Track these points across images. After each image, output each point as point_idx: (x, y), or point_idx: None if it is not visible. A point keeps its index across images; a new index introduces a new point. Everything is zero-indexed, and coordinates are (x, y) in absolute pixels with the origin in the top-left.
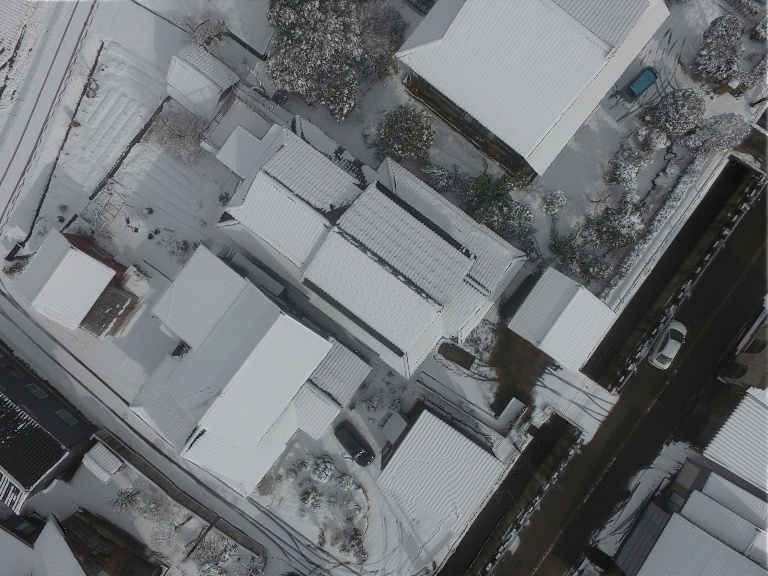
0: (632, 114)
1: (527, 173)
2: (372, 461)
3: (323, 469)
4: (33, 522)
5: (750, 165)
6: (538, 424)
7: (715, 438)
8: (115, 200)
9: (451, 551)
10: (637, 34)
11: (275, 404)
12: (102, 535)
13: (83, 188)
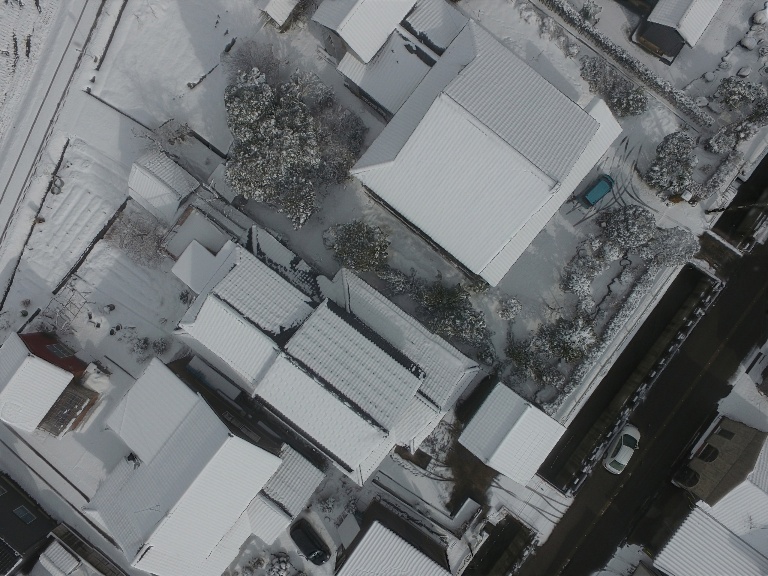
0: (589, 219)
1: None
2: (328, 560)
3: (277, 570)
4: None
5: (705, 272)
6: (494, 522)
7: (665, 549)
8: (78, 295)
9: None
10: (589, 151)
11: (224, 519)
12: None
13: (47, 283)
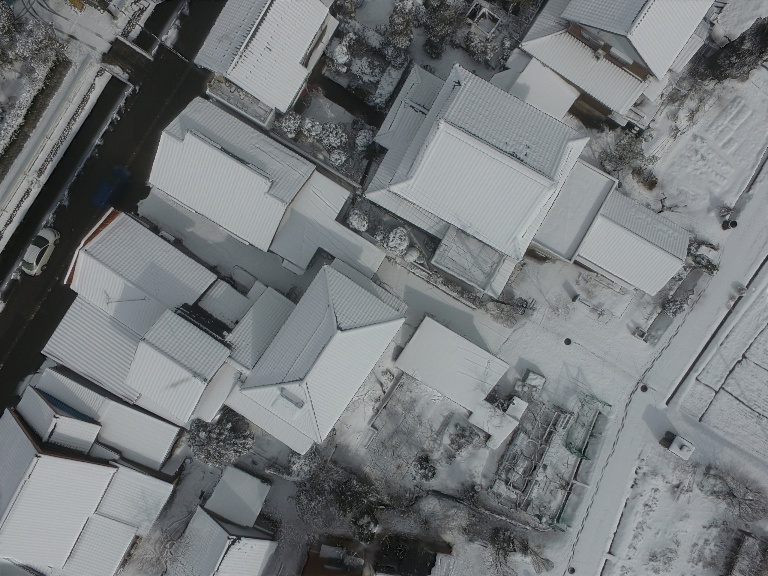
0: None
1: None
2: None
3: None
4: None
5: (116, 76)
6: None
7: (52, 335)
8: None
9: None
10: None
11: None
12: None
13: None
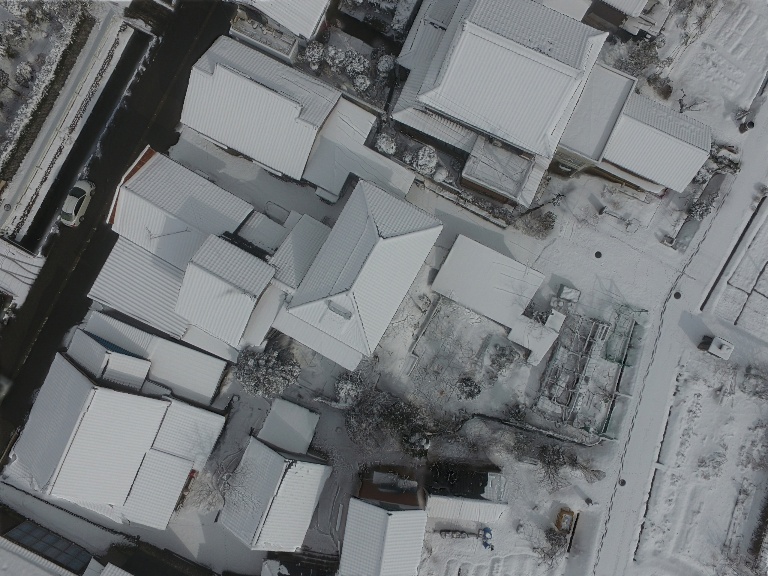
0: None
1: None
2: None
3: None
4: None
5: (139, 29)
6: None
7: (96, 279)
8: None
9: None
10: None
11: None
12: None
13: None
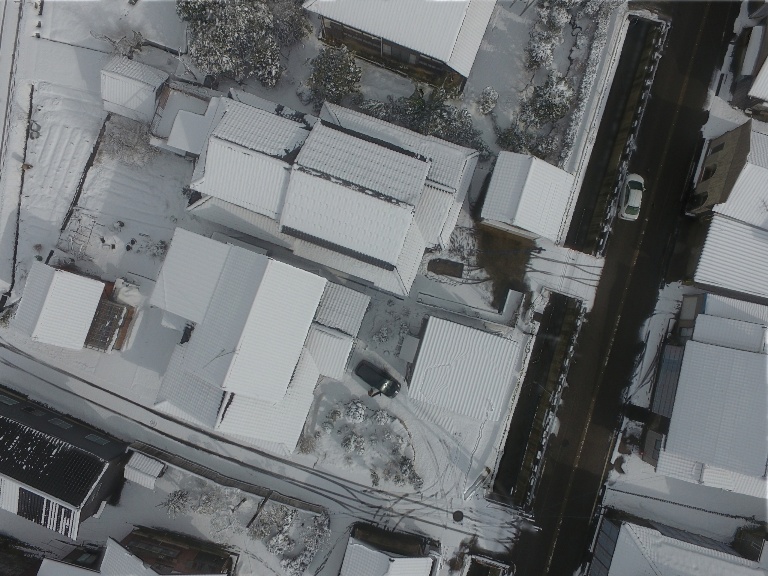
0: (531, 6)
1: (456, 84)
2: (399, 390)
3: (355, 409)
4: (93, 553)
5: (649, 18)
6: (541, 310)
7: (700, 263)
8: (85, 225)
9: (500, 453)
10: None
11: (290, 350)
12: (164, 542)
13: (52, 223)
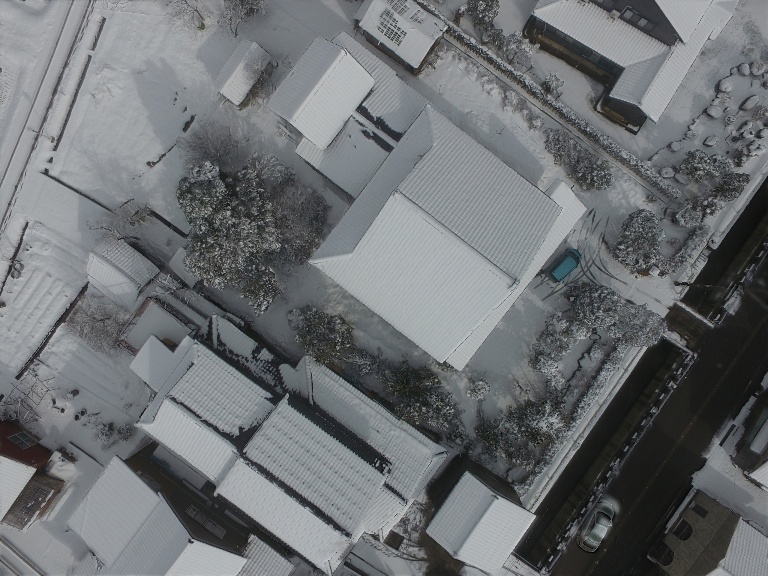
0: (557, 293)
1: None
2: None
3: None
4: None
5: (676, 344)
6: None
7: None
8: None
9: None
10: (553, 232)
11: None
12: None
13: (9, 368)
